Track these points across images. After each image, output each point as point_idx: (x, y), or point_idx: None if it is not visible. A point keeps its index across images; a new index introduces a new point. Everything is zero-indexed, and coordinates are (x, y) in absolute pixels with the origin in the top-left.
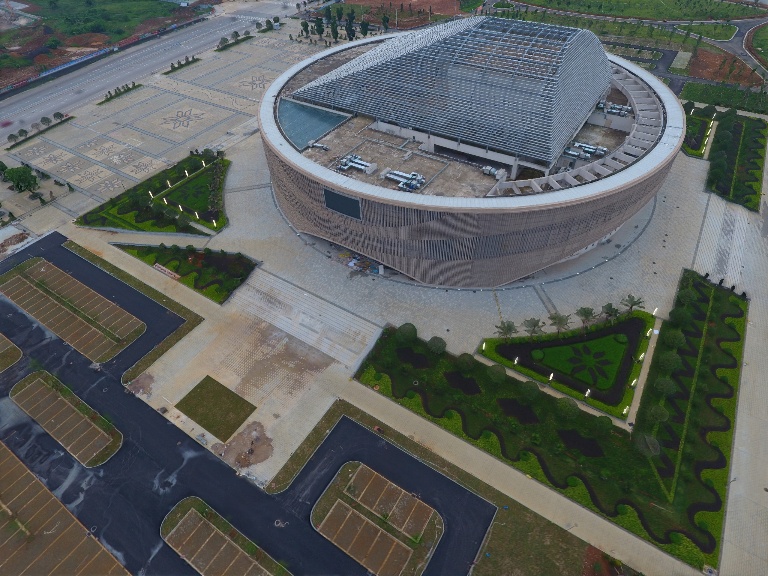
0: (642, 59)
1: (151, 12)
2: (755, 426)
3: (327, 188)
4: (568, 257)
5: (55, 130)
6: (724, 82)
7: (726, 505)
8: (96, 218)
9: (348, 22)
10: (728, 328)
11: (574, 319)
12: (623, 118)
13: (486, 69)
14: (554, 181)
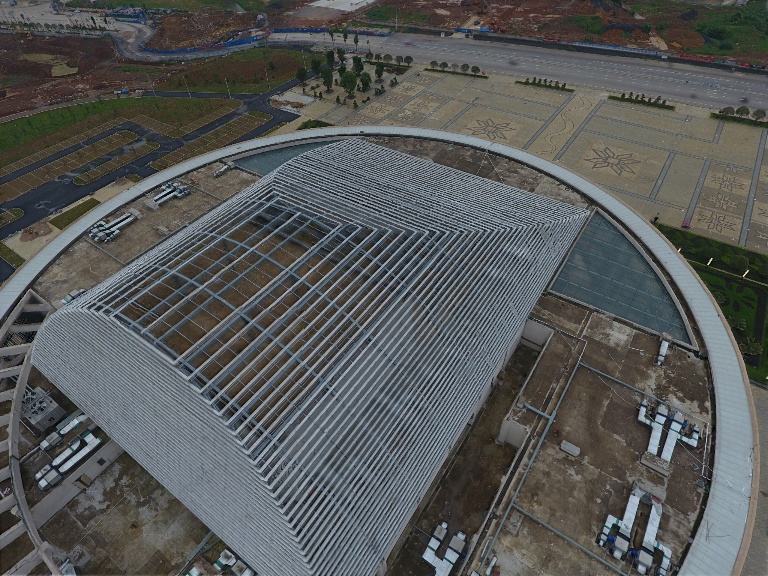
0: None
1: None
2: None
3: None
4: None
5: (460, 77)
6: None
7: None
8: (307, 125)
9: None
10: None
11: None
12: None
13: None
14: (8, 368)
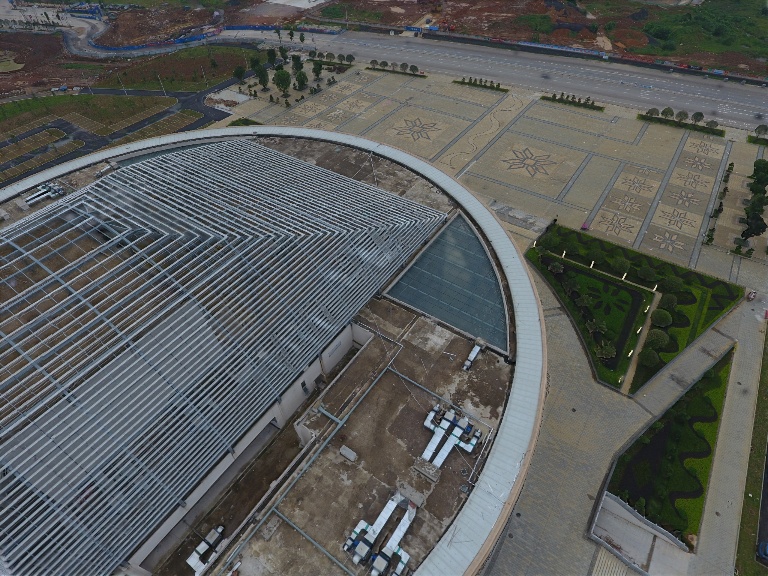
0: None
1: None
2: None
3: None
4: None
5: (399, 76)
6: None
7: None
8: None
9: None
10: None
11: None
12: None
13: None
14: None
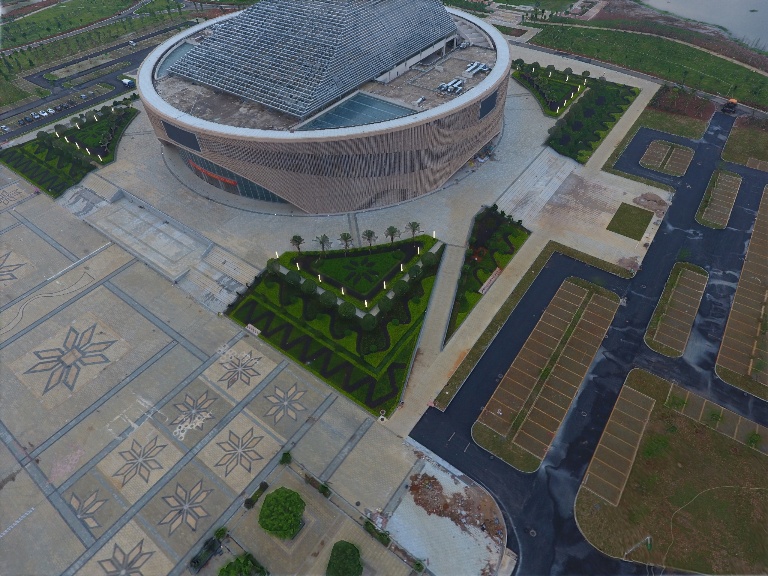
0: None
1: None
2: None
3: None
4: None
5: None
6: None
7: None
8: (388, 380)
9: None
10: None
11: (522, 91)
12: None
13: None
14: (472, 34)
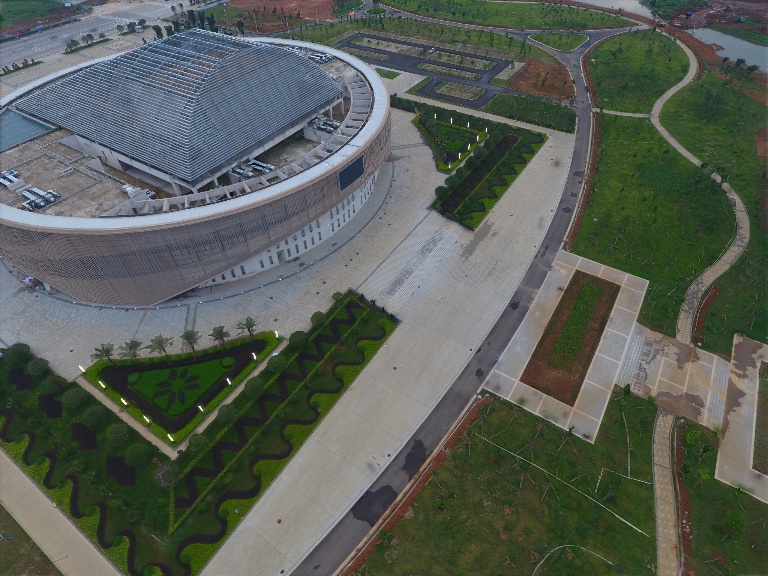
0: (472, 69)
1: (30, 12)
2: (314, 454)
3: None
4: (240, 275)
5: None
6: (519, 95)
7: (228, 537)
8: None
9: (201, 26)
10: (356, 351)
11: (203, 340)
12: (327, 134)
13: (147, 85)
14: (185, 201)
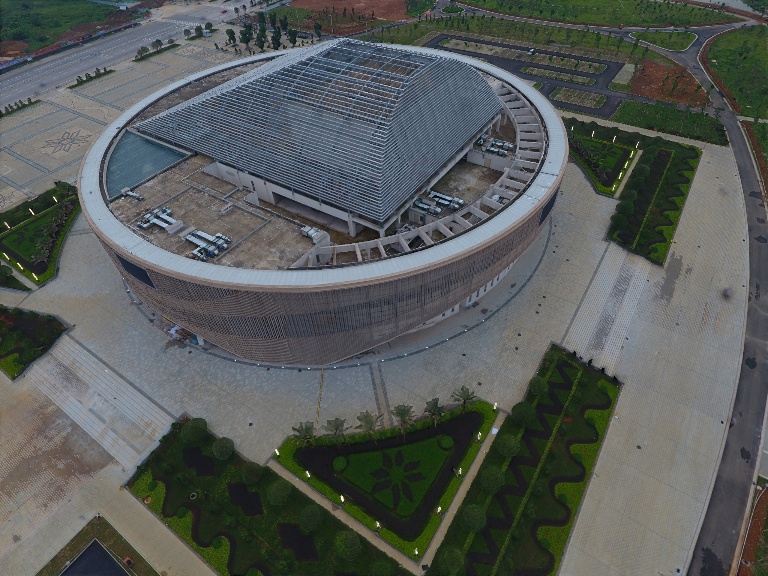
0: (583, 73)
1: (86, 16)
2: (584, 568)
3: (116, 252)
4: (420, 326)
5: None
6: (659, 103)
7: None
8: None
9: (277, 30)
10: (586, 425)
11: None
12: (501, 158)
13: (318, 107)
14: (380, 246)
